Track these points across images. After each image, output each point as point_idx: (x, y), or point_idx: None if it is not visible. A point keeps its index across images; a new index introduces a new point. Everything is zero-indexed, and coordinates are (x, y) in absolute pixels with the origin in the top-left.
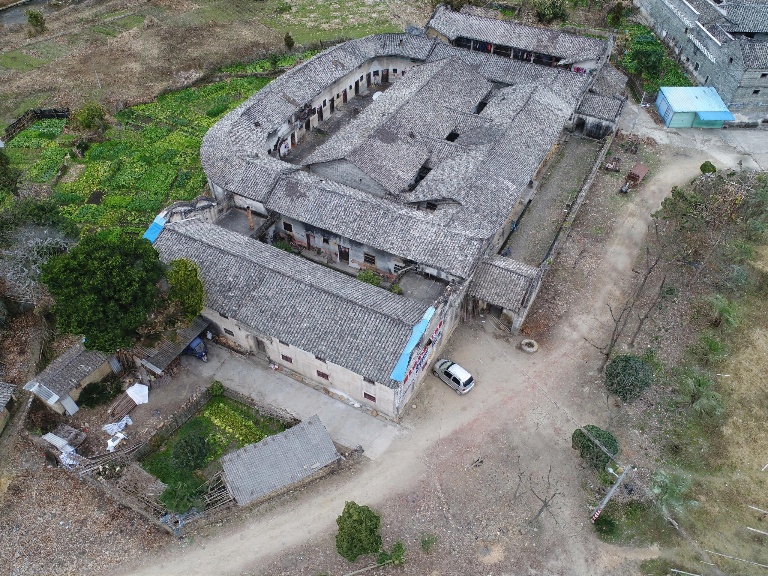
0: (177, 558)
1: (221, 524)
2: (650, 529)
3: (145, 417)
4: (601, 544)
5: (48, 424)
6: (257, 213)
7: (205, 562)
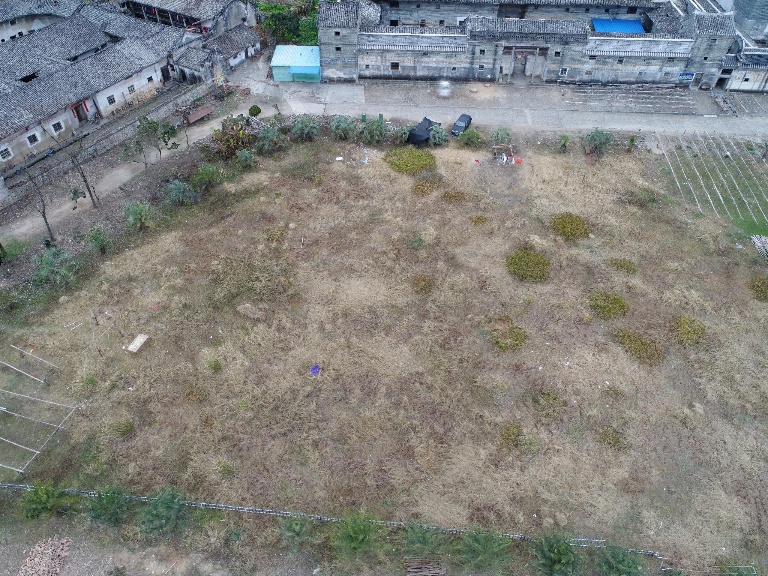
0: None
1: None
2: None
3: None
4: None
5: None
6: None
7: None
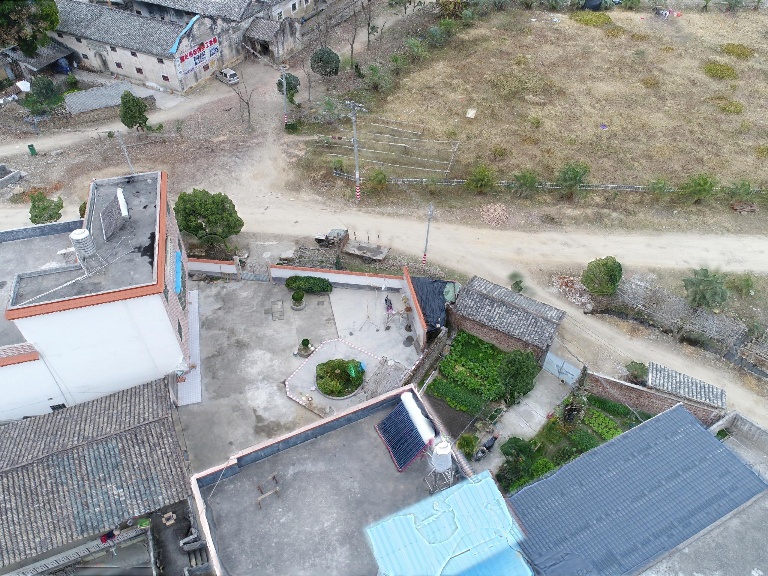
0: (34, 140)
1: (63, 128)
2: (319, 130)
3: None
4: (286, 135)
5: None
6: (117, 3)
7: (50, 141)
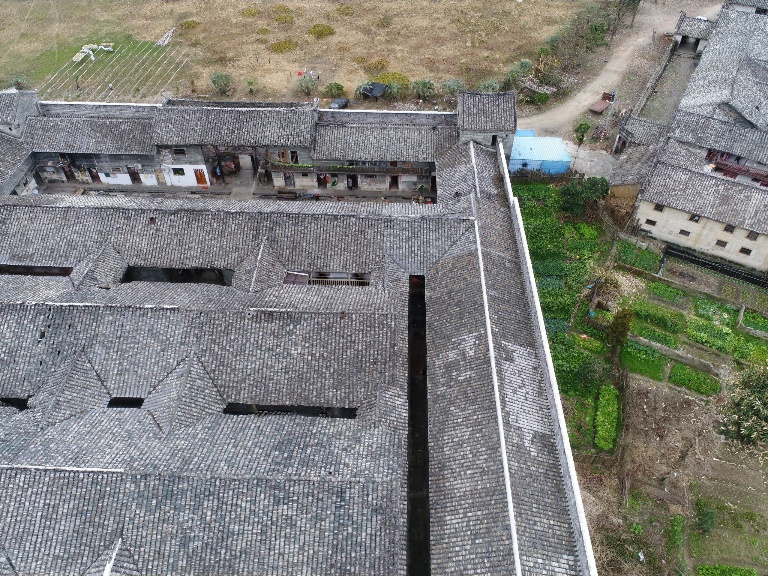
0: None
1: None
2: (612, 2)
3: None
4: None
5: None
6: None
7: None
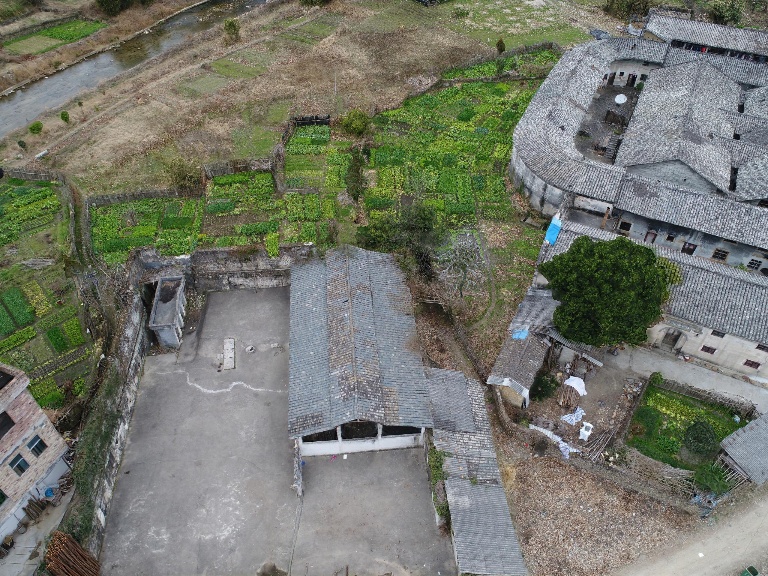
0: (712, 535)
1: (734, 503)
2: None
3: (593, 408)
4: None
5: (517, 416)
6: (599, 213)
7: (740, 538)
